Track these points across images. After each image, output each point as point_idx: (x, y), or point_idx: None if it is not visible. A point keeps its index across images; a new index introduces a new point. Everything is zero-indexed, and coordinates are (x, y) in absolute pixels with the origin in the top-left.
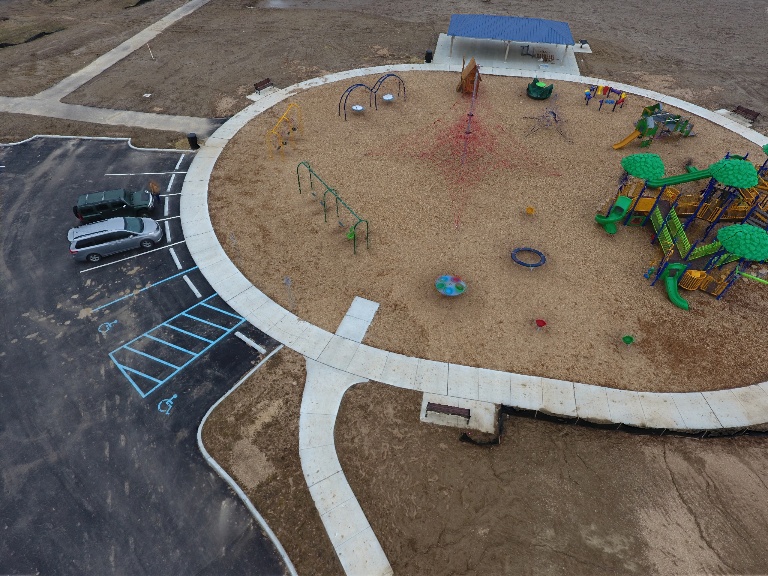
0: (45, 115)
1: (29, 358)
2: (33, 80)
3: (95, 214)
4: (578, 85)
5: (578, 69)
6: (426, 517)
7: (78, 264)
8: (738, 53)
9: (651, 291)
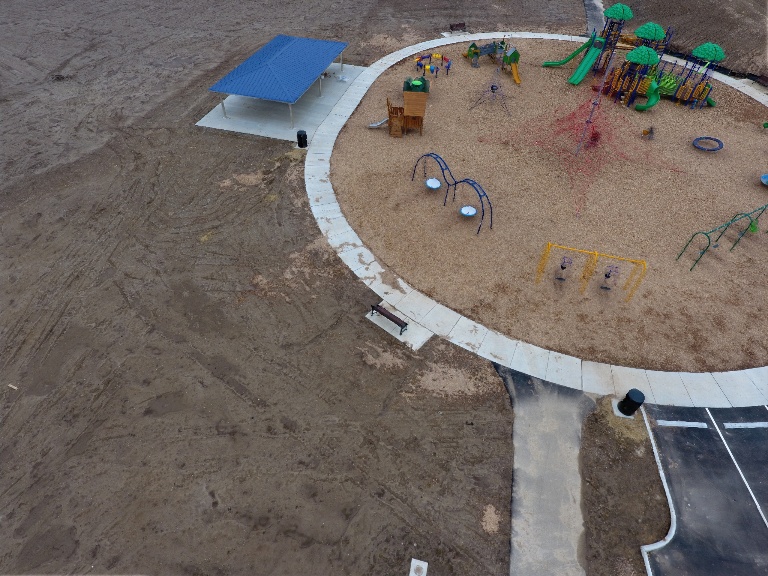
0: None
1: None
2: None
3: None
4: (390, 73)
5: (351, 65)
6: None
7: None
8: (326, 4)
9: (705, 111)
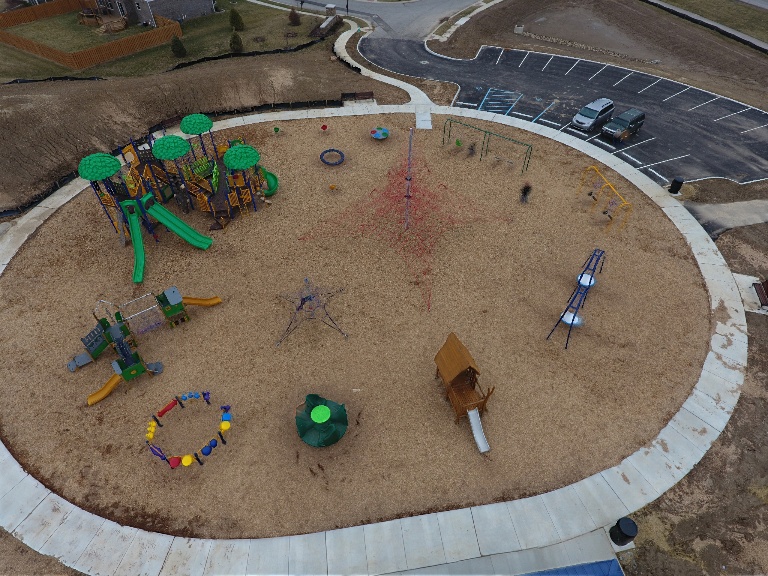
0: None
1: None
2: None
3: None
4: (224, 520)
5: None
6: None
7: None
8: None
9: None
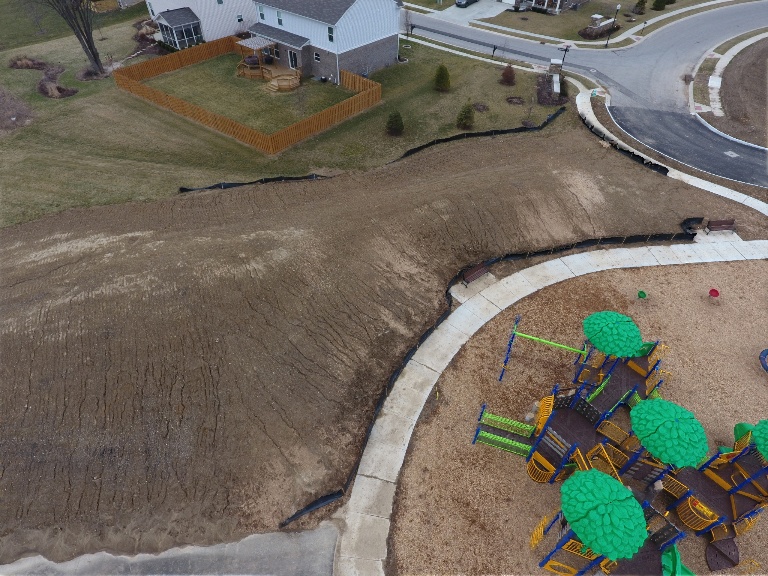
0: None
1: None
2: None
3: None
4: None
5: None
6: None
7: None
8: None
9: None
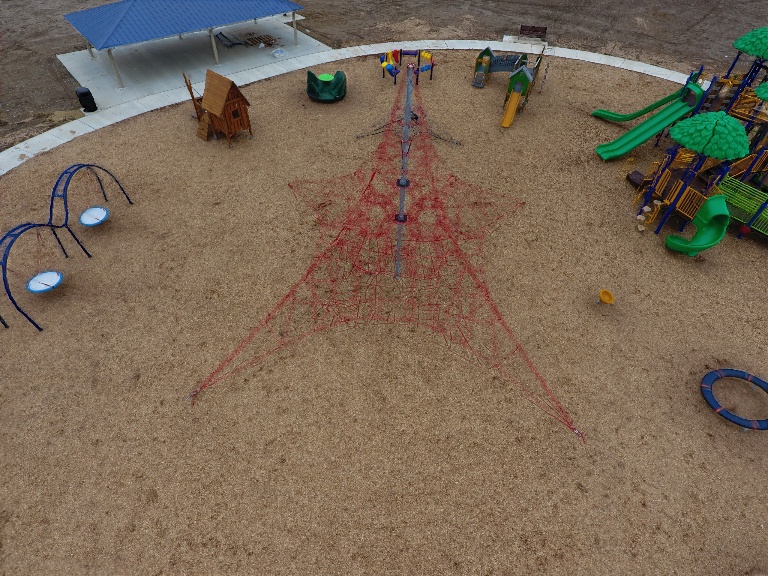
0: None
1: None
2: None
3: None
4: (349, 62)
5: (320, 42)
6: None
7: None
8: None
9: None
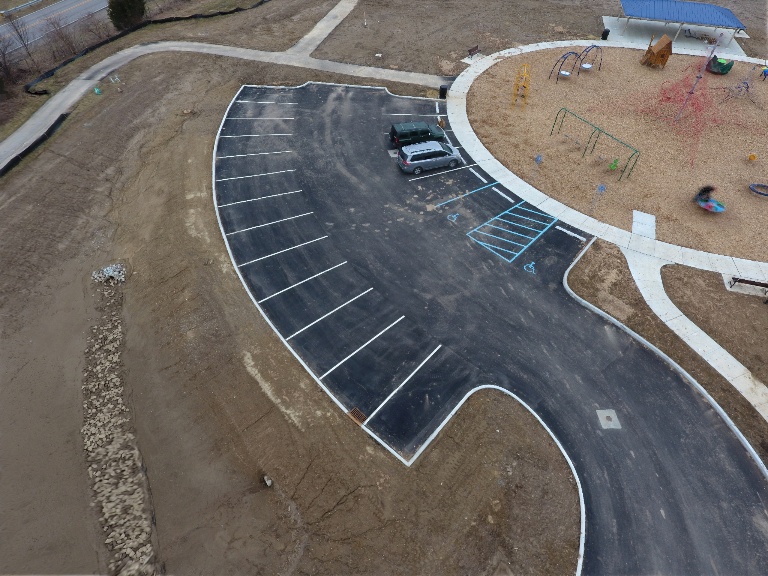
0: (306, 67)
1: (408, 233)
2: (276, 39)
3: (408, 139)
4: (748, 64)
5: (743, 51)
6: (762, 344)
7: (404, 175)
8: None
9: None
